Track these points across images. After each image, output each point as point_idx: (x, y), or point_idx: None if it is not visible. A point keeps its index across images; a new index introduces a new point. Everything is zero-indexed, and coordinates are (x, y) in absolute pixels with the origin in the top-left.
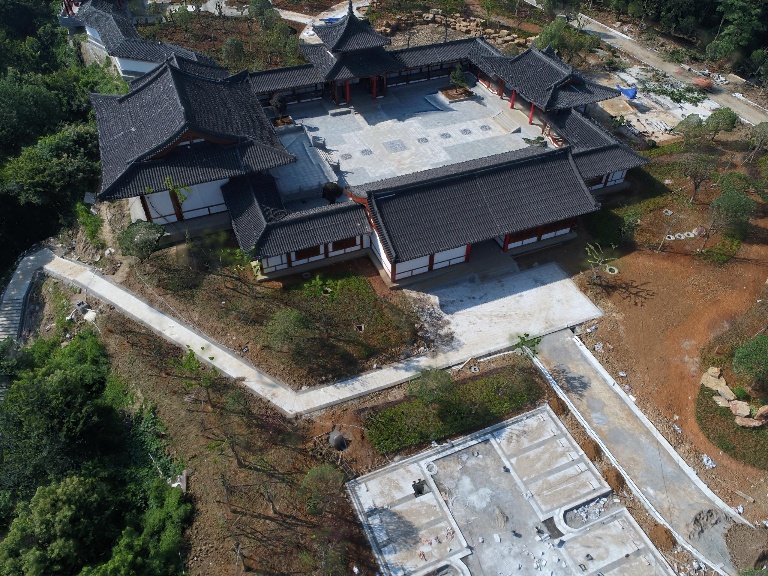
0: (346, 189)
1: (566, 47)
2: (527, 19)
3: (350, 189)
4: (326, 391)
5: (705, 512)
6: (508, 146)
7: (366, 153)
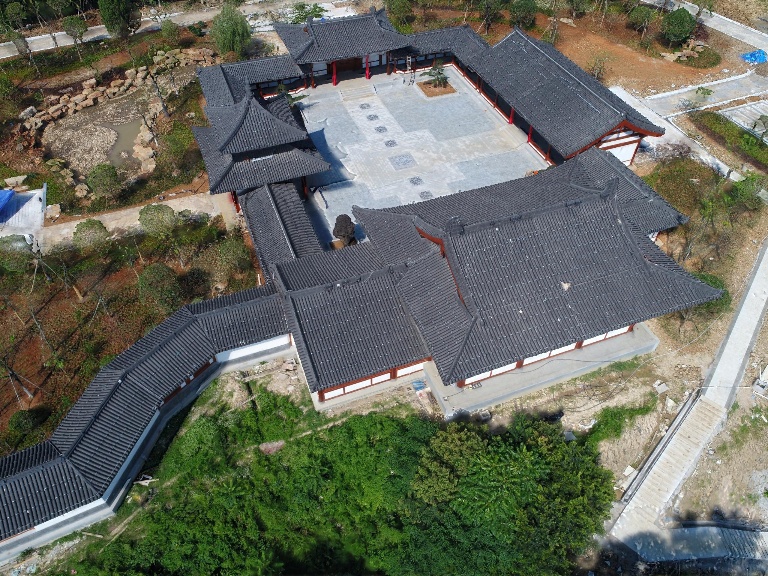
0: (568, 154)
1: (189, 44)
2: (99, 55)
3: (570, 151)
4: (766, 198)
5: (759, 77)
6: (401, 98)
7: (418, 181)
